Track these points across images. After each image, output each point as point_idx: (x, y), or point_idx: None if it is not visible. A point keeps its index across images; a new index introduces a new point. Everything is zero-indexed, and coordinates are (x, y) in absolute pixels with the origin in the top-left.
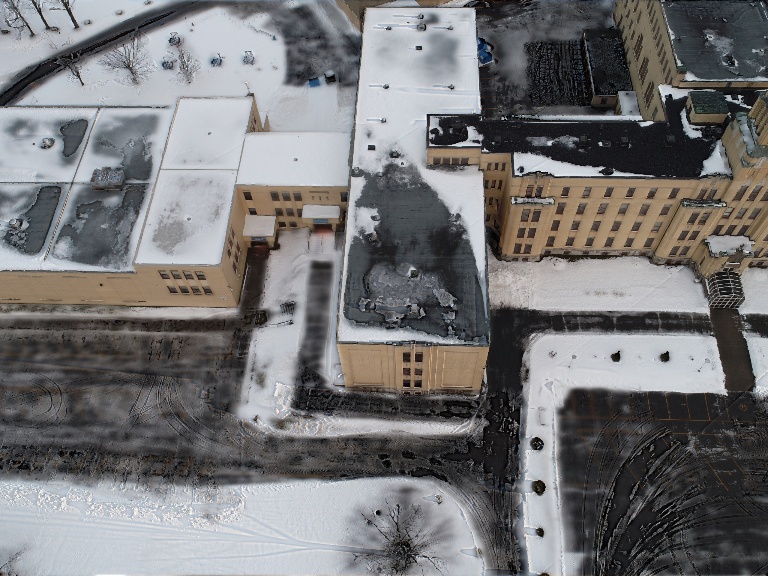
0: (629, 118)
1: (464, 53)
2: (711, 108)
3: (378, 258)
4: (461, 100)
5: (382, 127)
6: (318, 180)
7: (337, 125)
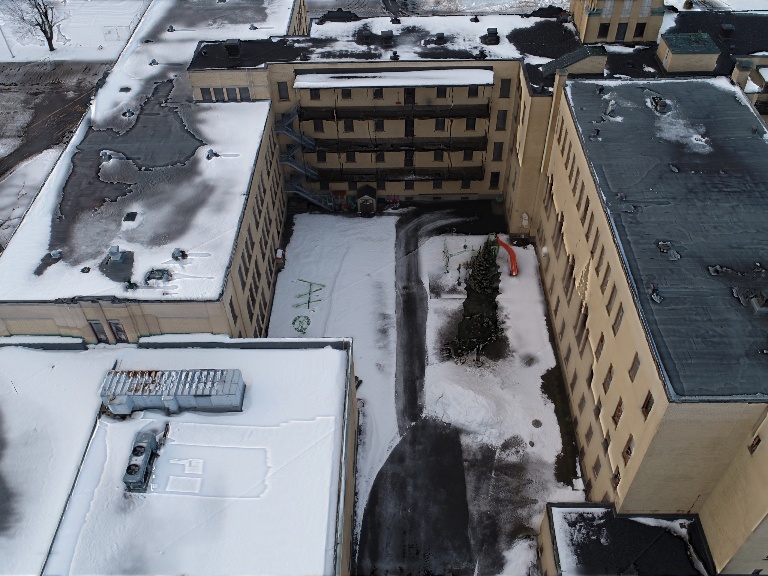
0: None
1: None
2: (688, 37)
3: None
4: None
5: None
6: None
7: None
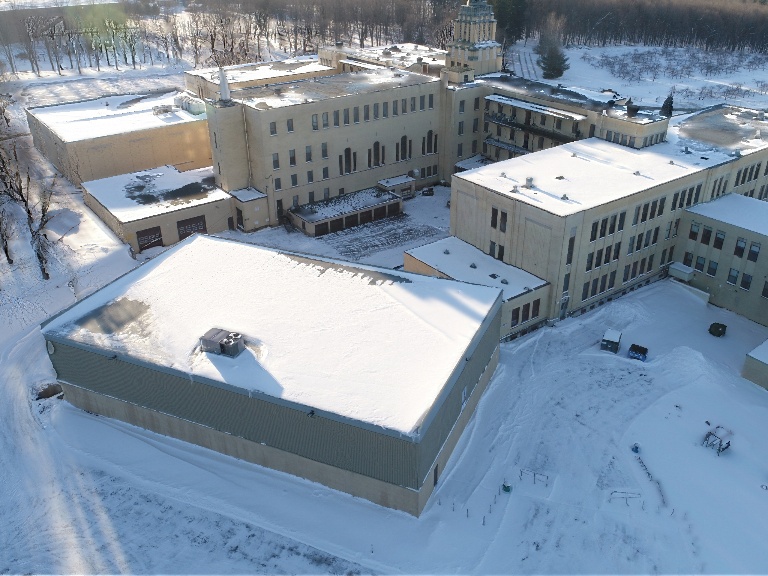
0: (495, 98)
1: (525, 163)
2: None
3: (765, 133)
4: (581, 150)
5: (679, 162)
6: (764, 204)
7: (653, 315)
